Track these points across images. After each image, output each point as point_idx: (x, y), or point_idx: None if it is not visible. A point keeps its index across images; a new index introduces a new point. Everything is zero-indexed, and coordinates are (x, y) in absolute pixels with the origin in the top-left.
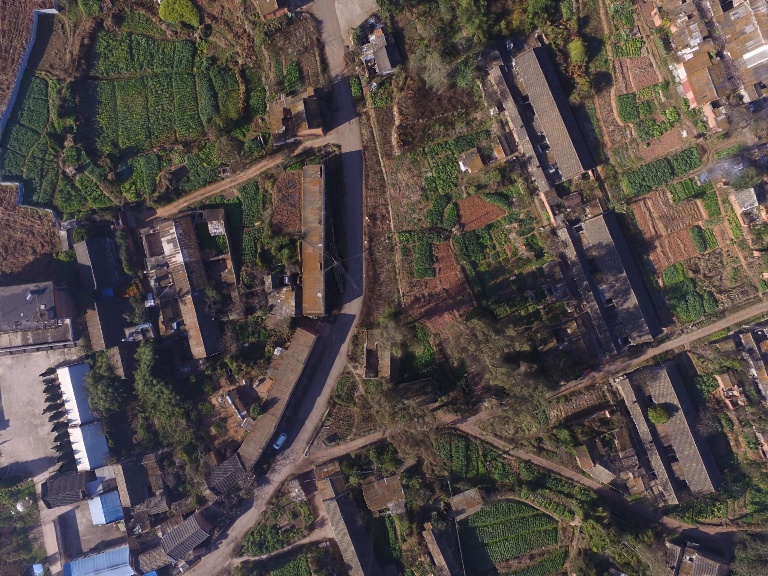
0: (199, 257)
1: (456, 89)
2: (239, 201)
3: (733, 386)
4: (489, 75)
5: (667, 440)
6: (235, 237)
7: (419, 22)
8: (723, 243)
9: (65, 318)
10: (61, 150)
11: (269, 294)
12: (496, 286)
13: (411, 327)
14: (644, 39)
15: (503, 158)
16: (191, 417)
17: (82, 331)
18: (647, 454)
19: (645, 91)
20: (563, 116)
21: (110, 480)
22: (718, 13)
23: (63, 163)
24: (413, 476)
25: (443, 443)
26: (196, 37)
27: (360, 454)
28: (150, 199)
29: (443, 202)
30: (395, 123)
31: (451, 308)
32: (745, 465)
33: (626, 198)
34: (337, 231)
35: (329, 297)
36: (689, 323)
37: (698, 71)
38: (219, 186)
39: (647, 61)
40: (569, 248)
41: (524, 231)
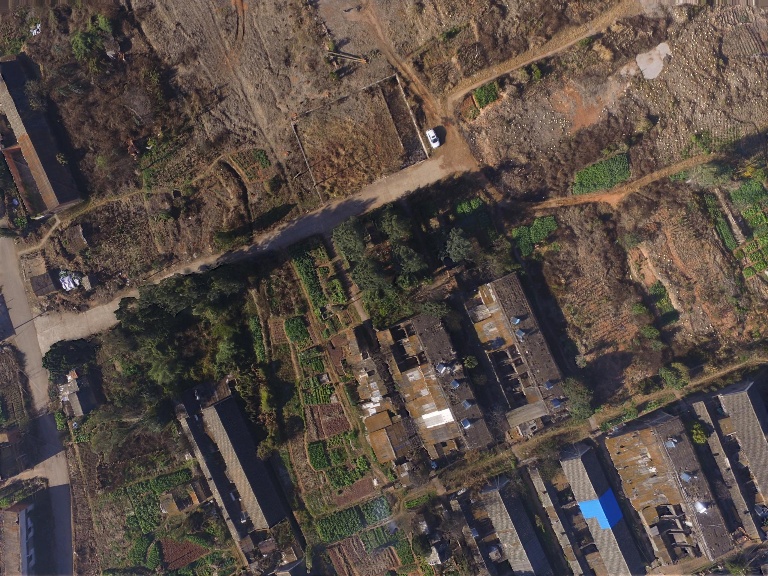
0: None
1: None
2: None
3: None
4: None
5: None
6: None
7: (117, 360)
8: None
9: None
10: None
11: None
12: None
13: None
14: (334, 386)
15: None
16: None
17: None
18: None
19: (335, 439)
20: (248, 472)
21: None
22: (396, 372)
23: None
24: None
25: None
26: None
27: None
28: None
29: (144, 543)
30: (98, 459)
31: None
32: None
33: (322, 542)
34: (46, 566)
35: None
36: None
37: (377, 431)
38: None
39: (337, 408)
40: None
41: (226, 571)
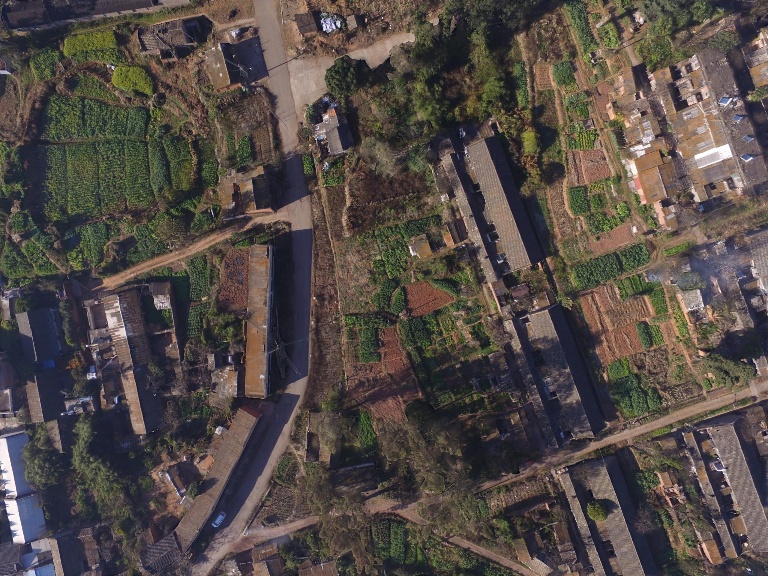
0: (143, 331)
1: (408, 172)
2: (187, 274)
3: (673, 485)
4: (442, 160)
5: (606, 535)
6: (181, 311)
7: (374, 103)
8: (669, 340)
9: (4, 389)
10: (8, 215)
11: (212, 372)
12: (441, 373)
13: (354, 411)
14: (598, 132)
15: (453, 245)
16: (130, 492)
17: (23, 400)
18: (586, 547)
19: (597, 185)
20: (512, 208)
21: (46, 552)
22: (671, 112)
23: (9, 229)
24: (349, 564)
25: (382, 529)
26: (150, 104)
27: (298, 537)
28: (95, 270)
29: (391, 286)
30: (346, 203)
31: (395, 393)
32: (683, 561)
33: (574, 291)
34: (284, 310)
35: (273, 377)
36: (633, 418)
37: (649, 170)
38: (167, 258)
39: (600, 154)
40: (514, 340)
41: (471, 319)
